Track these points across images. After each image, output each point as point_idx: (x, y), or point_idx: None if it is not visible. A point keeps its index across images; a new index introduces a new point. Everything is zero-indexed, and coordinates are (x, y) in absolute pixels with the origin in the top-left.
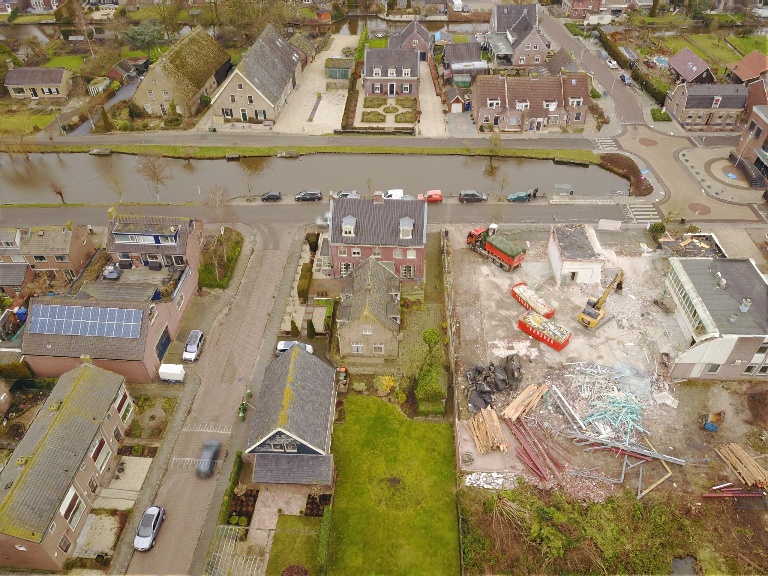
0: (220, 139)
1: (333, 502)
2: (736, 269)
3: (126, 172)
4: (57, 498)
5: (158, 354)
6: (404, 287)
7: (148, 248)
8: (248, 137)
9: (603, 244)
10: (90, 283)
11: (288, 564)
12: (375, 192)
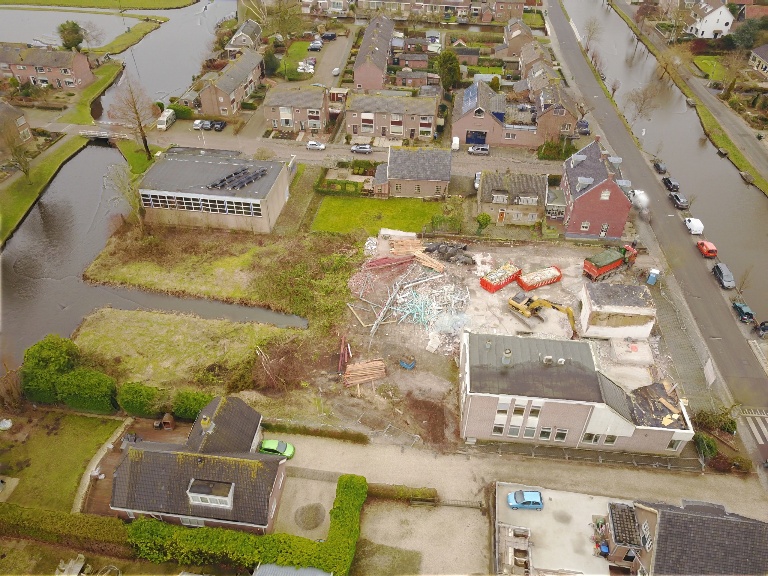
0: (746, 142)
1: (369, 198)
2: (581, 385)
3: (676, 118)
4: (365, 109)
5: (469, 138)
6: (555, 226)
7: (539, 105)
8: (761, 154)
9: (671, 364)
10: (503, 96)
11: (337, 185)
12: (604, 151)
